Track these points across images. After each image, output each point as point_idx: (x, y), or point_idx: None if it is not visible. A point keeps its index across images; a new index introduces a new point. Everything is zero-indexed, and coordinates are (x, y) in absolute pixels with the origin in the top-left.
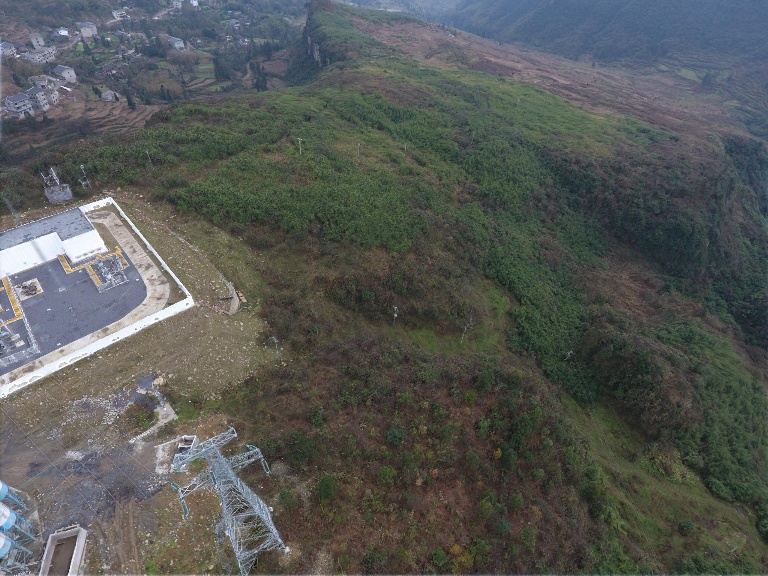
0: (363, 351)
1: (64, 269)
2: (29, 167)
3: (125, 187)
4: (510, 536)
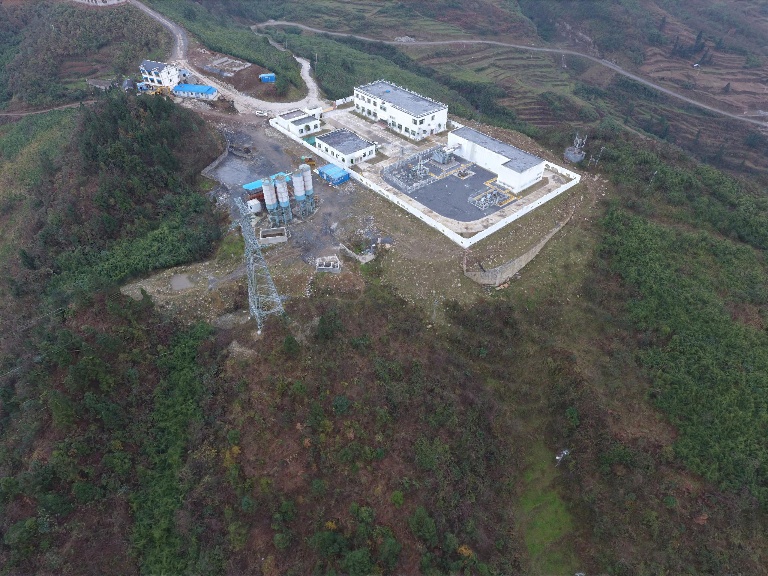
0: (454, 389)
1: (488, 181)
2: (595, 132)
3: (610, 183)
4: (244, 517)
